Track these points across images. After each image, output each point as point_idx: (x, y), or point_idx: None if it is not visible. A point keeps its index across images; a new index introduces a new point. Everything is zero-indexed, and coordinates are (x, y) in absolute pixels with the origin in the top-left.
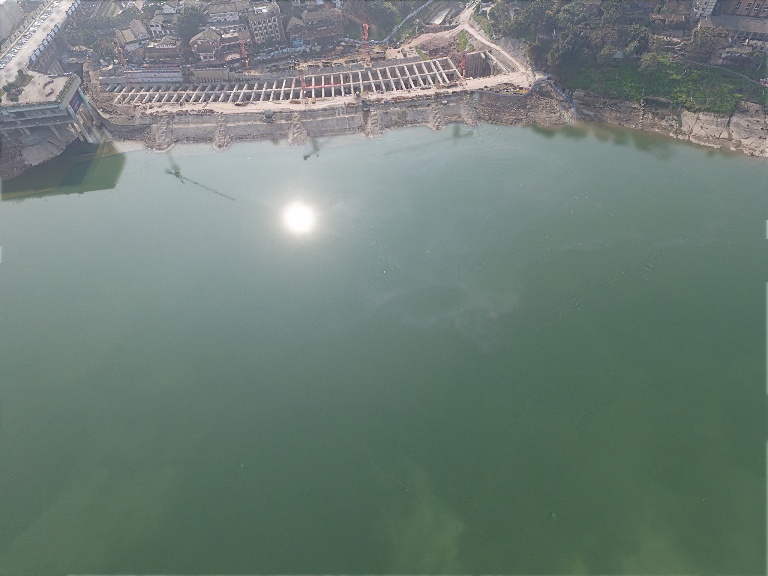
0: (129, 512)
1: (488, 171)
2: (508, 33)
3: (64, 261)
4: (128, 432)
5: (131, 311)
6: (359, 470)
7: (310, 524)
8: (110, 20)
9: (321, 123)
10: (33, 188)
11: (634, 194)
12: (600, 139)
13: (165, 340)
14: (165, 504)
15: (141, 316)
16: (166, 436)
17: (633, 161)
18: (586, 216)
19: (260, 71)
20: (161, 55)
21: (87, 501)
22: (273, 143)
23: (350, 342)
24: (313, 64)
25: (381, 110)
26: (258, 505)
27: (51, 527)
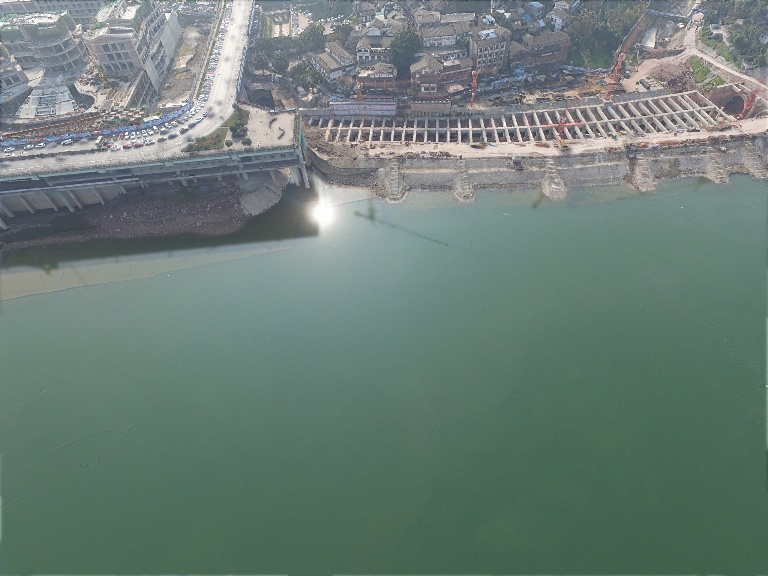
0: None
1: None
2: (767, 63)
3: (341, 349)
4: None
5: (459, 428)
6: None
7: None
8: (293, 40)
9: (580, 172)
10: (264, 245)
11: None
12: None
13: (519, 474)
14: None
15: (473, 436)
16: None
17: None
18: None
19: (485, 105)
20: (373, 85)
21: None
22: (525, 195)
23: None
24: (541, 97)
25: (649, 157)
26: None
27: None
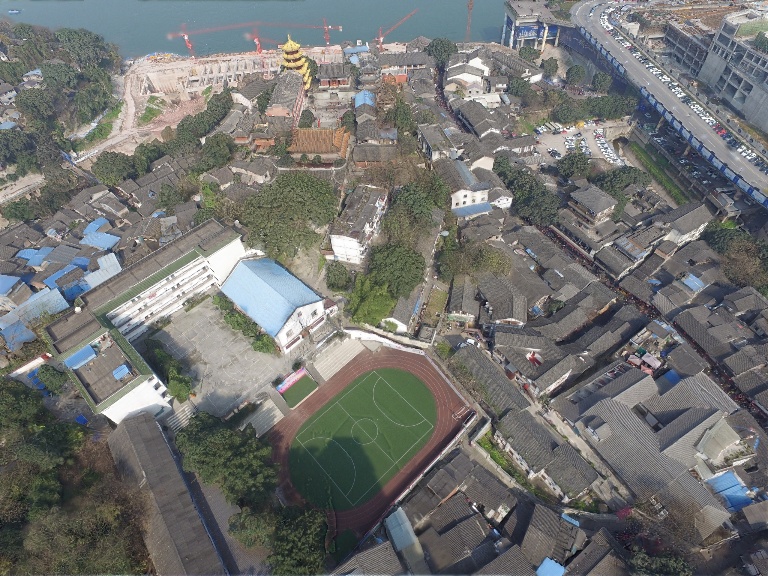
0: None
1: (221, 34)
2: None
3: (457, 4)
4: None
5: None
6: None
7: None
8: None
9: None
10: None
11: (153, 25)
12: (132, 49)
13: None
14: None
15: None
16: None
17: (131, 38)
18: (189, 17)
19: None
20: None
21: None
22: None
23: None
24: None
25: None
26: None
27: None
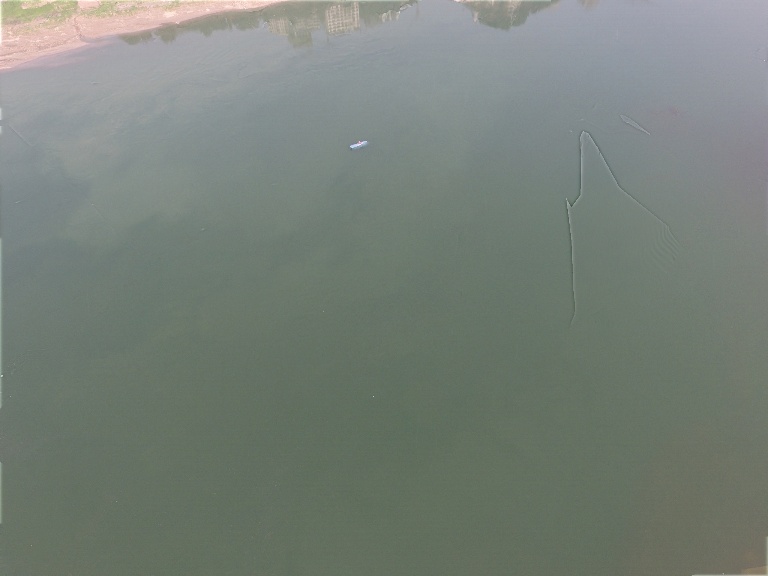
0: (278, 211)
1: None
2: None
3: (423, 430)
4: (287, 248)
5: (306, 344)
6: (124, 226)
7: (163, 200)
8: None
9: None
10: None
11: None
12: None
13: (266, 315)
14: (255, 213)
15: (294, 340)
16: (258, 246)
17: None
18: None
19: None
20: None
21: (305, 214)
22: None
23: (86, 302)
24: None
25: None
26: (195, 211)
27: (322, 203)
